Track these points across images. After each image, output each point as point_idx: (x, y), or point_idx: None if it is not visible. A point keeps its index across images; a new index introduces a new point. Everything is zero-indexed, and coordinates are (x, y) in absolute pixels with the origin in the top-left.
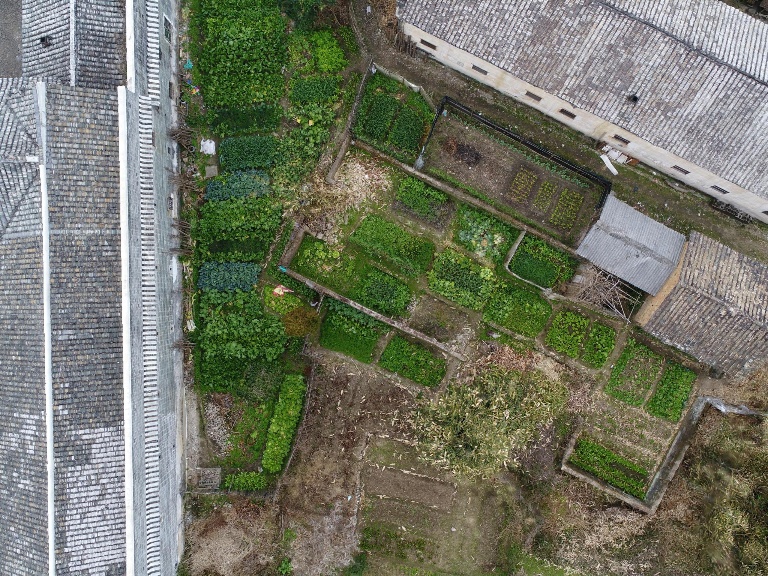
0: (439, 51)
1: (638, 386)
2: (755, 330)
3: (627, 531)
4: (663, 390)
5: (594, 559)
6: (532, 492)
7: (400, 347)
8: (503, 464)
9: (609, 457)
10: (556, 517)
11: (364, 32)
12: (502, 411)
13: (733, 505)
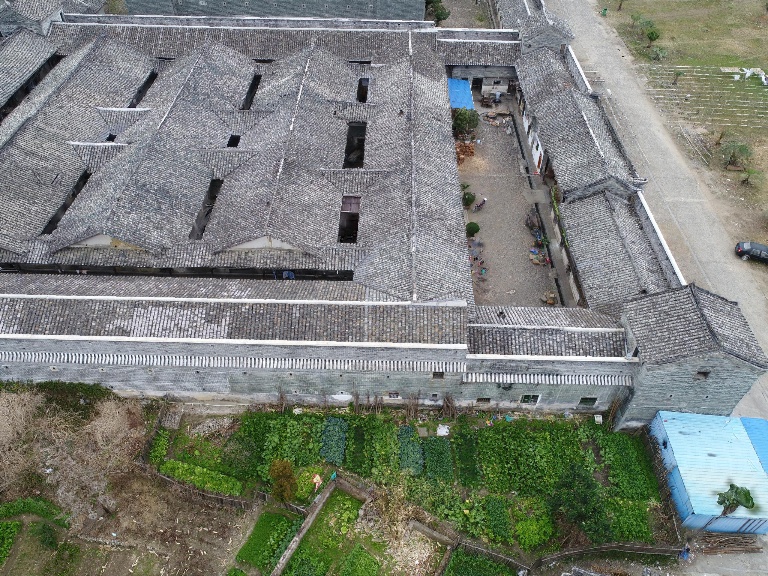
0: None
1: None
2: None
3: None
4: None
5: None
6: None
7: None
8: None
9: None
10: None
11: (559, 569)
12: None
13: None
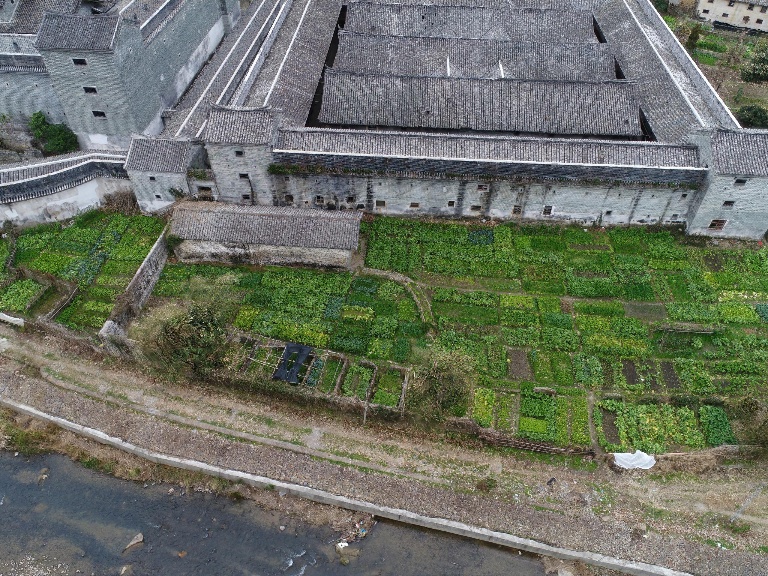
0: (709, 13)
1: None
2: None
3: None
4: None
5: None
6: None
7: None
8: None
9: None
10: None
11: None
12: None
13: None
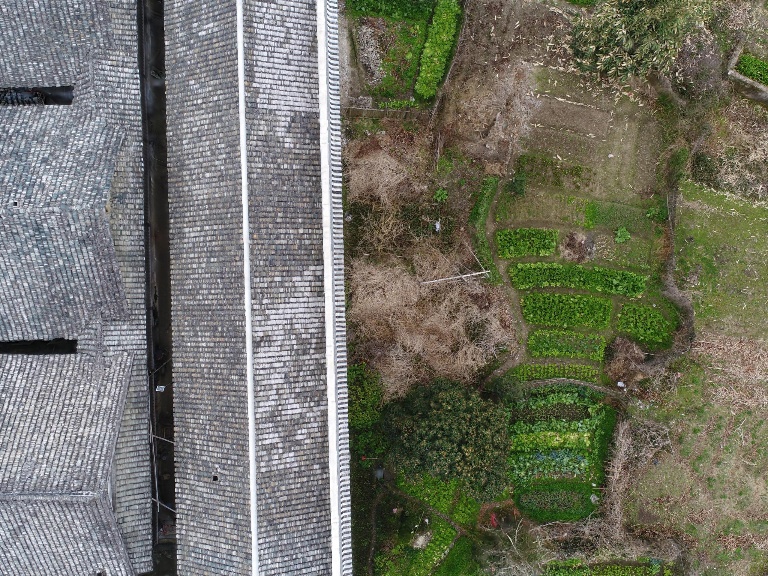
0: None
1: None
2: None
3: None
4: None
5: (757, 178)
6: (696, 104)
7: None
8: None
9: None
10: (716, 140)
11: None
12: None
13: None
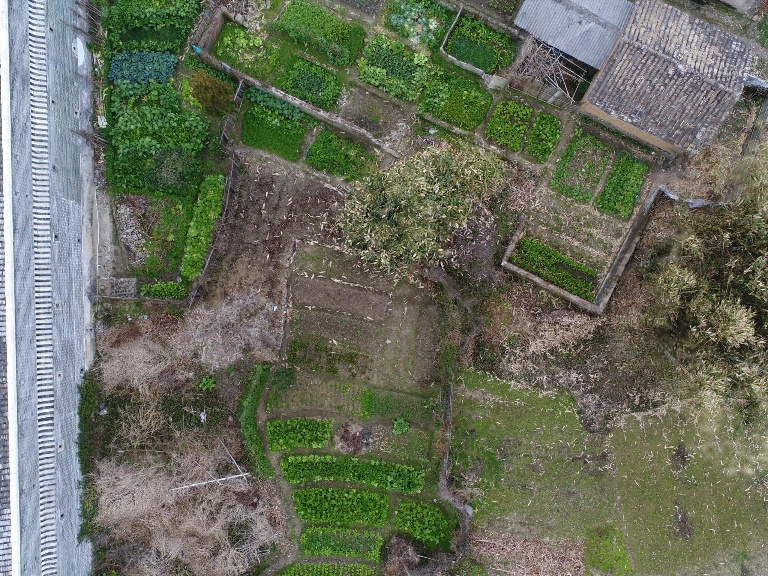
0: None
1: (586, 180)
2: (706, 90)
3: (574, 335)
4: (613, 183)
5: (540, 369)
6: (471, 293)
7: (328, 140)
8: (440, 265)
9: (555, 256)
10: (499, 326)
11: None
12: (431, 185)
13: (680, 267)
